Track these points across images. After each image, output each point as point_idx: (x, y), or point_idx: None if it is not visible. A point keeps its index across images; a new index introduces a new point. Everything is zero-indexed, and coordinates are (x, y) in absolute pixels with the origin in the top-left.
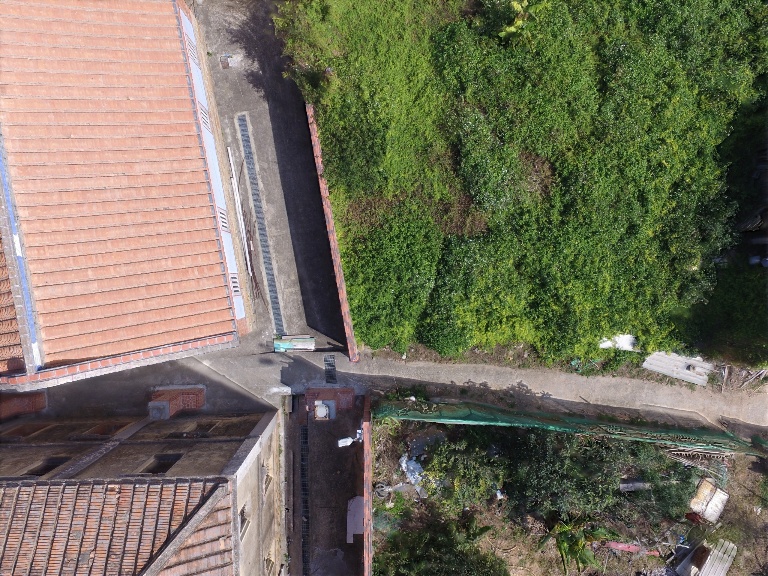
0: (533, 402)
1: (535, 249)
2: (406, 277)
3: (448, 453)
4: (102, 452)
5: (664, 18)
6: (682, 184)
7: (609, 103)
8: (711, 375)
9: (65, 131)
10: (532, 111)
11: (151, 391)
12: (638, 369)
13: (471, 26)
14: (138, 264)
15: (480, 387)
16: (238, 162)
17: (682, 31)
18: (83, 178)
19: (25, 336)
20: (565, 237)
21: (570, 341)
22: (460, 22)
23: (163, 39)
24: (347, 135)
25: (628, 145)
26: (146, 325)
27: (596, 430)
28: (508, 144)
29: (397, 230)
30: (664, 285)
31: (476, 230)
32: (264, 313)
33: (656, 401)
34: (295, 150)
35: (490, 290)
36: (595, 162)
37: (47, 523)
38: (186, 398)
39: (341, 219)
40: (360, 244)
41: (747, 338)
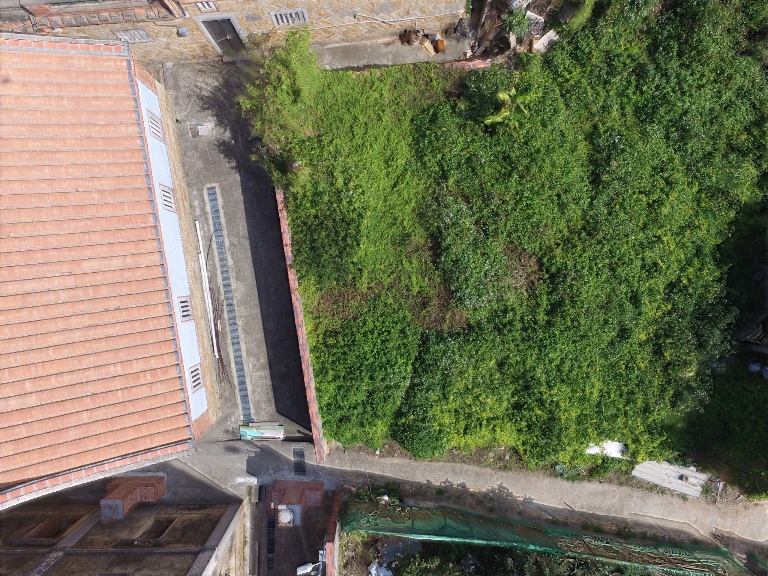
0: (514, 506)
1: (519, 350)
2: (379, 377)
3: (419, 571)
4: (41, 570)
5: (663, 108)
6: (679, 285)
7: (602, 197)
8: (705, 485)
9: (4, 230)
10: (519, 203)
11: (108, 478)
12: (627, 476)
13: (455, 110)
14: (83, 372)
15: (458, 488)
16: (207, 237)
17: (682, 123)
18: (23, 281)
19: None
20: (551, 340)
21: (554, 447)
22: (444, 105)
23: (119, 123)
24: (319, 224)
25: (621, 243)
26: (90, 438)
27: (580, 541)
28: (492, 238)
29: (371, 325)
30: (657, 393)
31: (456, 326)
32: (231, 397)
33: (645, 510)
34: (268, 225)
35: (470, 392)
36: (585, 260)
37: None
38: (143, 490)
39: (311, 310)
40: (331, 338)
41: (744, 459)
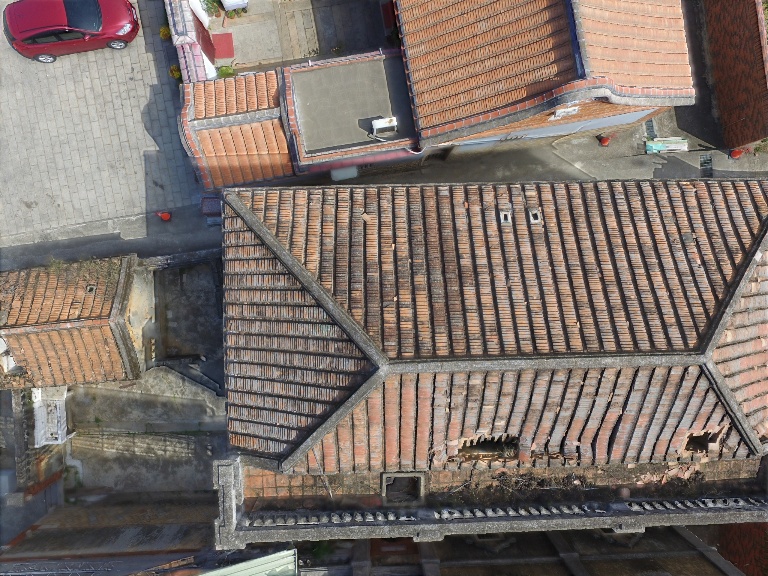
0: None
1: None
2: None
3: None
4: None
5: None
6: None
7: None
8: None
9: None
10: None
11: None
12: None
13: None
14: (630, 3)
15: None
16: None
17: None
18: None
19: (583, 41)
20: None
21: None
22: None
23: None
24: None
25: None
26: (639, 64)
27: None
28: None
29: None
30: None
31: None
32: None
33: None
34: None
35: None
36: None
37: (638, 210)
38: None
39: None
40: None
41: None
